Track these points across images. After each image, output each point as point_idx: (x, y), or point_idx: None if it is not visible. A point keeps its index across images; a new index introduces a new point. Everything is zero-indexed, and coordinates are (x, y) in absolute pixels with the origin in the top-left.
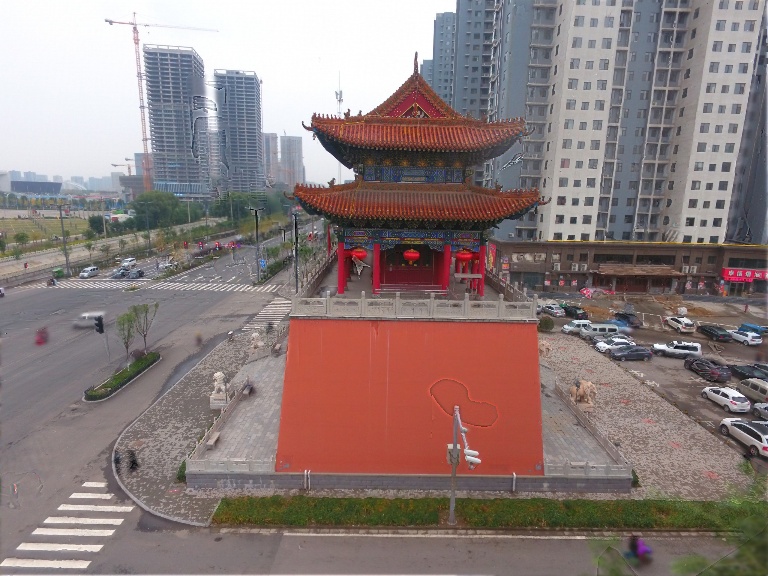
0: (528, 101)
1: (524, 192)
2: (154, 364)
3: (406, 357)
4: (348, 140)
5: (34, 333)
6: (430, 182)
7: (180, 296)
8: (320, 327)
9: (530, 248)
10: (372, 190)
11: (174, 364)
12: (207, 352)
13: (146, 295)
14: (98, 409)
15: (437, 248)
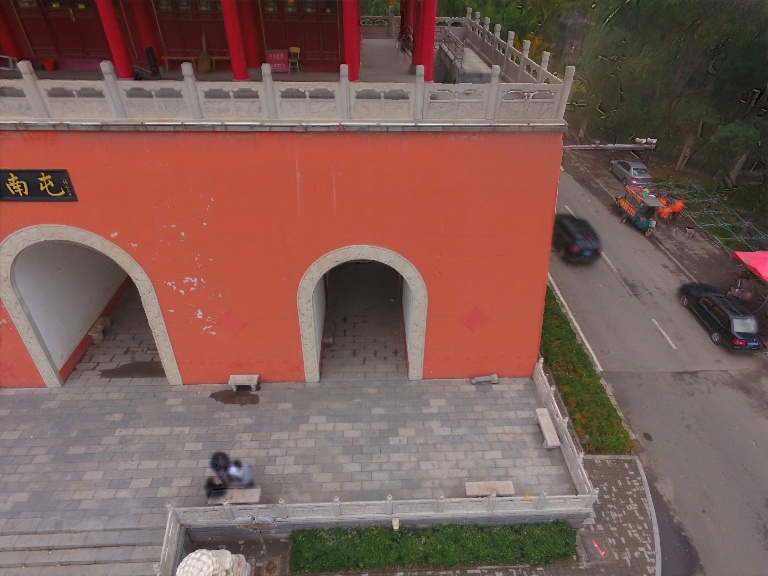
0: None
1: None
2: None
3: None
4: None
5: None
6: None
7: None
8: None
9: None
10: None
11: None
12: None
13: None
14: None
15: None
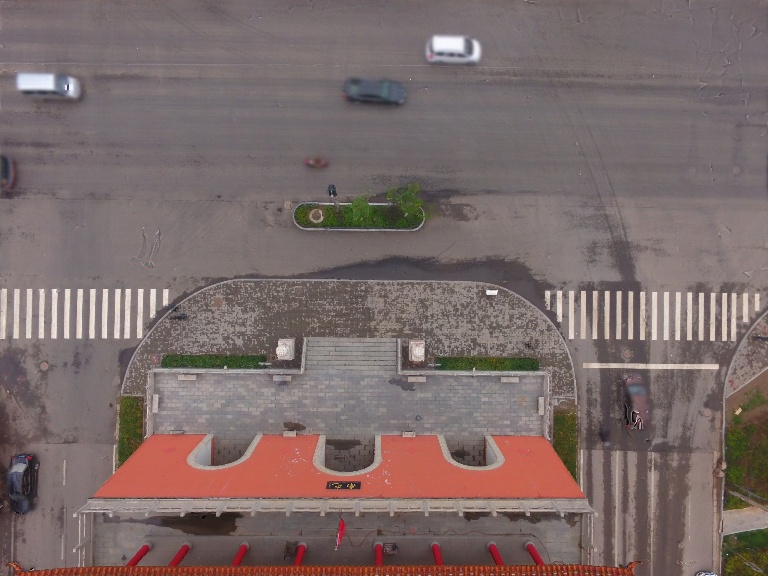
0: None
1: None
2: (395, 230)
3: None
4: None
5: (512, 4)
6: None
7: (760, 107)
8: None
9: None
10: None
11: (400, 252)
12: (444, 276)
13: (761, 40)
14: (282, 231)
15: None
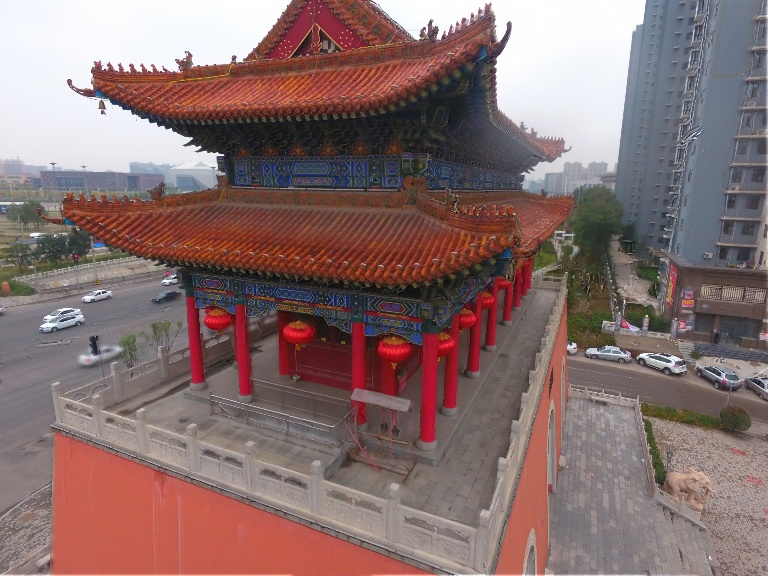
0: (756, 45)
1: (488, 216)
2: None
3: (208, 559)
4: (154, 109)
5: (124, 331)
6: (337, 187)
7: None
8: (88, 457)
9: (736, 279)
10: (242, 203)
11: None
12: None
13: None
14: None
15: (339, 325)
